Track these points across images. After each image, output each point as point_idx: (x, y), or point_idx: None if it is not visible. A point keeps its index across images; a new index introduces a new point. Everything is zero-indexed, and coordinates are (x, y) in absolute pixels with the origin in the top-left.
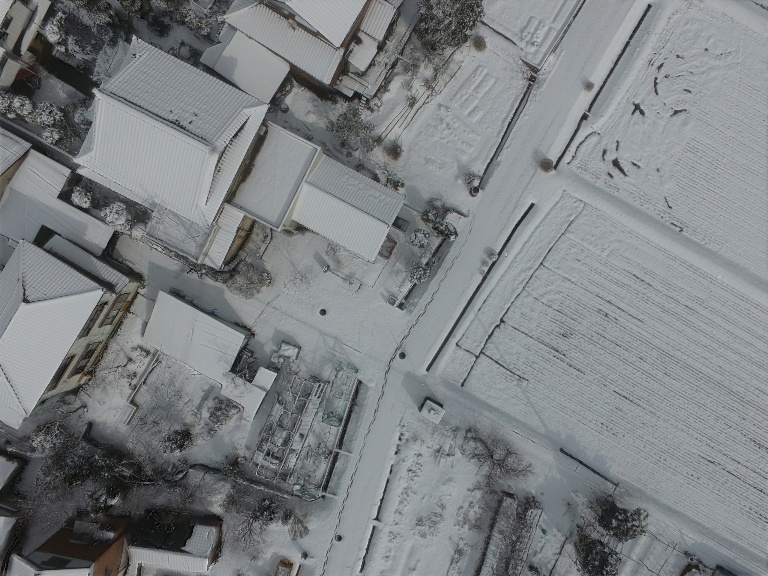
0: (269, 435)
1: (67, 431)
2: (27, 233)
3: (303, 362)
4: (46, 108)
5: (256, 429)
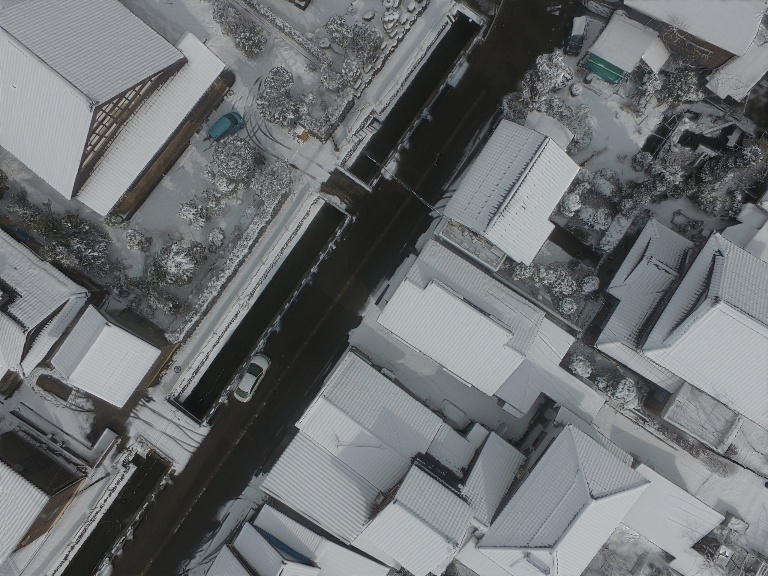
0: None
1: None
2: (527, 400)
3: (744, 535)
4: (564, 277)
5: None
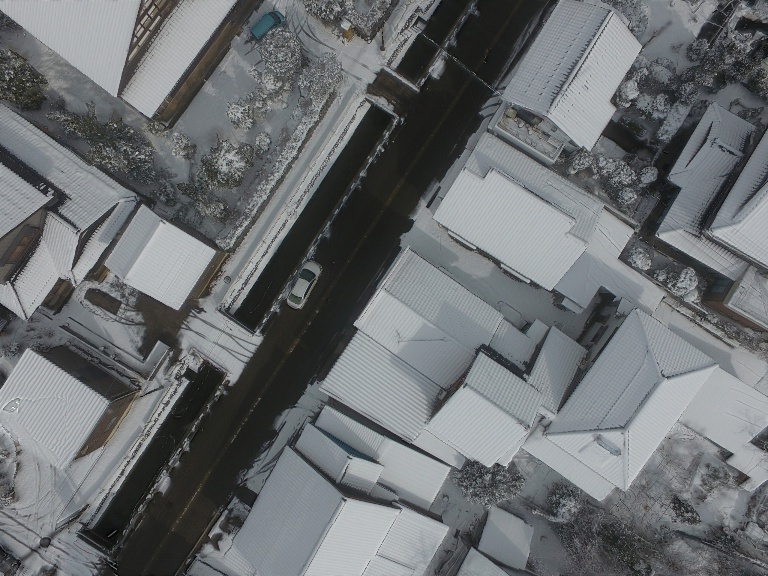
0: (767, 507)
1: (581, 495)
2: (587, 294)
3: None
4: (623, 167)
5: (743, 498)
